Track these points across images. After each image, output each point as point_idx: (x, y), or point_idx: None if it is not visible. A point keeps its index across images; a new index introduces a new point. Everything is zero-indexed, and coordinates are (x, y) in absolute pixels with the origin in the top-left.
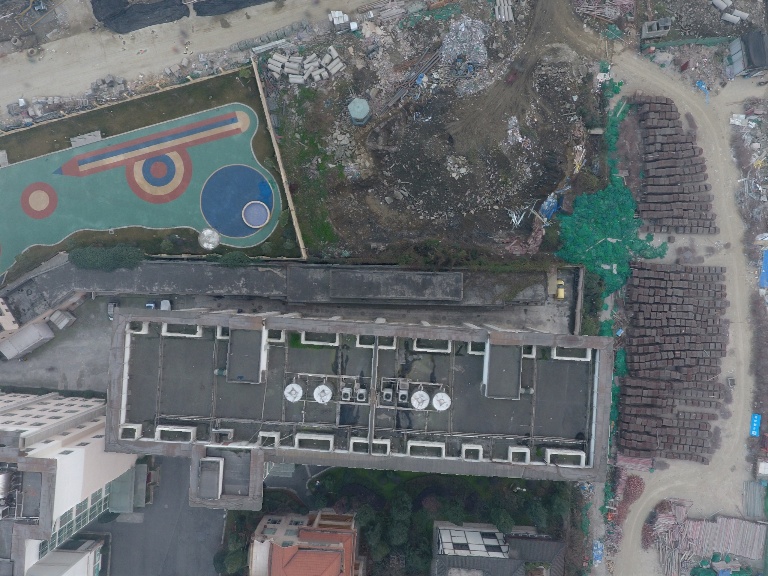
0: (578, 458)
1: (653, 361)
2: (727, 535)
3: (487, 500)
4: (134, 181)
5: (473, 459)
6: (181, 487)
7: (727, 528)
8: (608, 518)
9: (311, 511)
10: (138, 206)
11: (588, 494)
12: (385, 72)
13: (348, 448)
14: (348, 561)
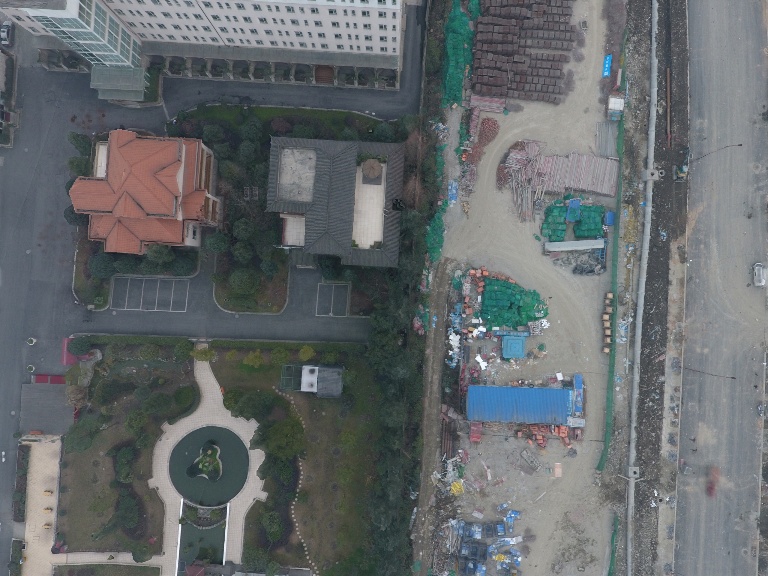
0: None
1: None
2: (578, 170)
3: None
4: None
5: None
6: (41, 131)
7: (578, 163)
8: (462, 157)
9: None
10: None
11: (442, 133)
12: None
13: None
14: (191, 166)
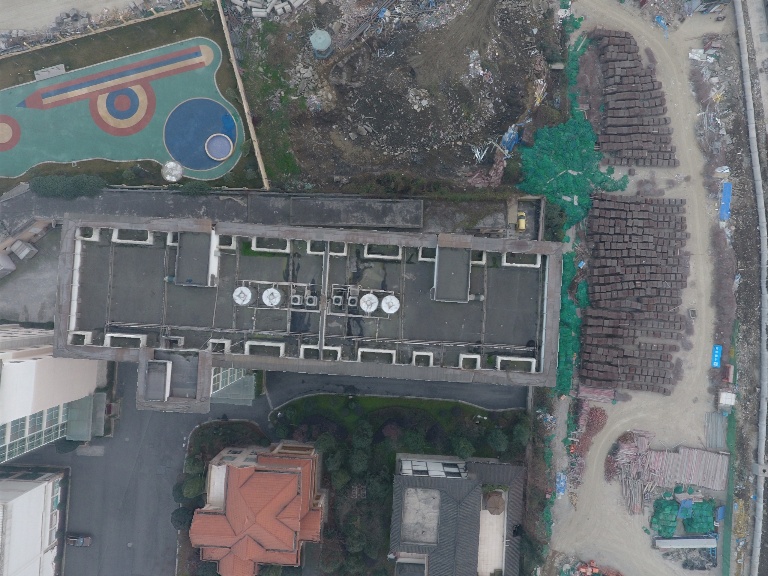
0: (529, 365)
1: (614, 291)
2: (689, 466)
3: (449, 432)
4: (98, 114)
5: (424, 366)
6: (142, 420)
7: (689, 459)
8: (571, 449)
9: (273, 443)
10: (101, 139)
11: (550, 425)
12: (348, 7)
13: (299, 355)
14: (306, 486)
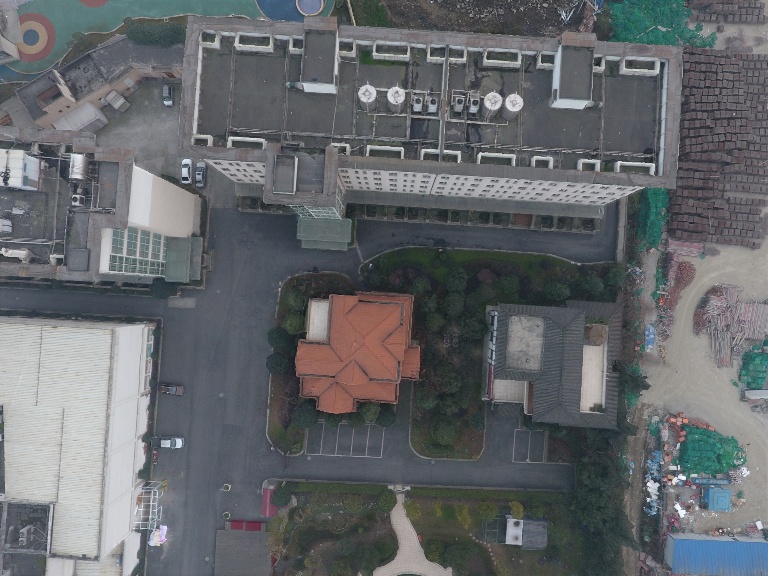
0: (646, 171)
1: (704, 143)
2: None
3: None
4: None
5: None
6: (233, 272)
7: None
8: (660, 302)
9: None
10: None
11: (640, 278)
12: None
13: None
14: (406, 323)
